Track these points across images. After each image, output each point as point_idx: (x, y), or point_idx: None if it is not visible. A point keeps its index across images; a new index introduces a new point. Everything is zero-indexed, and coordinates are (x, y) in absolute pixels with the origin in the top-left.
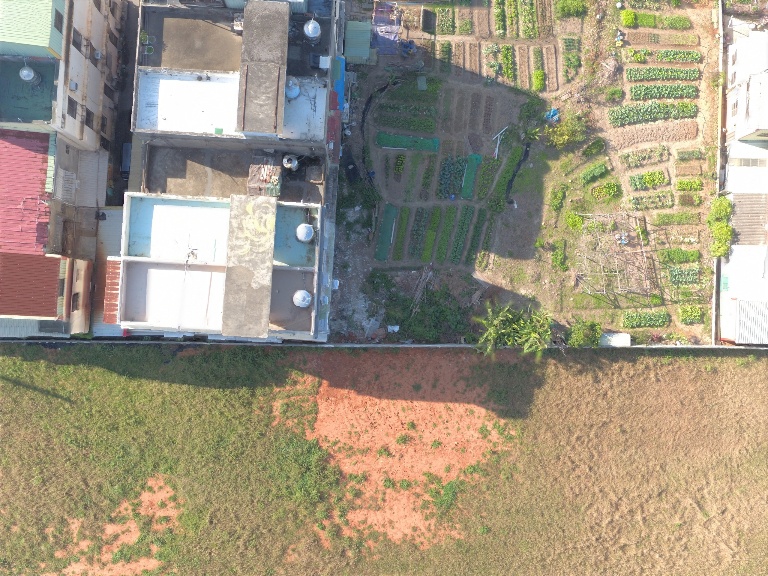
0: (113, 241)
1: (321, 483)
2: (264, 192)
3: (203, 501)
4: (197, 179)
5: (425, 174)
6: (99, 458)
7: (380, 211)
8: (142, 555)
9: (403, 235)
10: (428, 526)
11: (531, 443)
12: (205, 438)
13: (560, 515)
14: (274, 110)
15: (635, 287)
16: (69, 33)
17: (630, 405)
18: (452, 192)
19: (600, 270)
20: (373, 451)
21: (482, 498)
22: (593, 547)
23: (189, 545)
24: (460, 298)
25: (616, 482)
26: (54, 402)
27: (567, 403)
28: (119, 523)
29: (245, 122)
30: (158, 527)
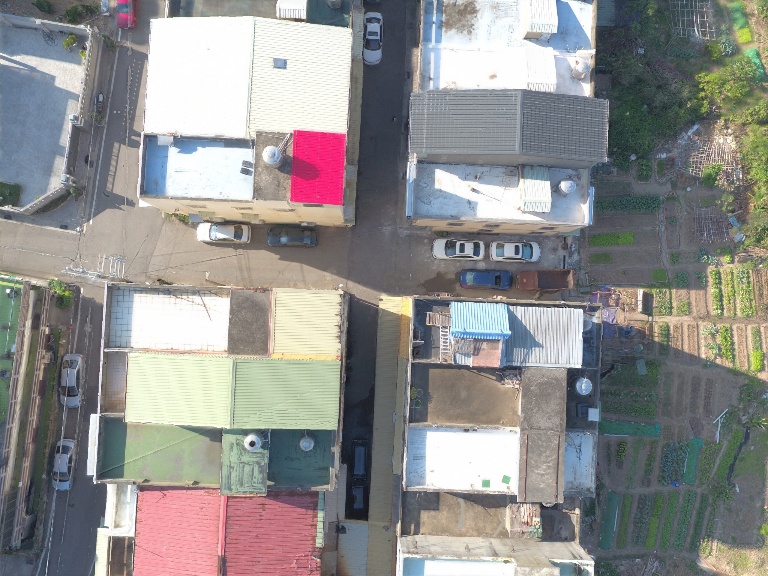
0: (354, 556)
1: None
2: (526, 535)
3: None
4: (450, 510)
5: (647, 461)
6: None
7: (603, 498)
8: None
9: (626, 523)
10: None
11: None
12: None
13: None
14: (555, 479)
15: None
16: (340, 392)
17: None
18: (674, 478)
19: None
20: None
21: None
22: None
23: None
24: None
25: None
26: None
27: None
28: None
29: (526, 492)
30: None
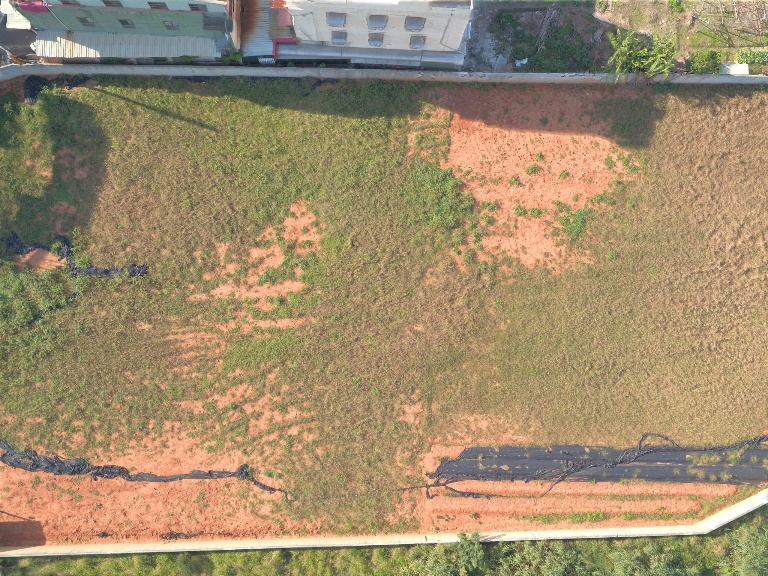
0: None
1: (456, 208)
2: None
3: (345, 225)
4: None
5: None
6: (244, 184)
7: None
8: (287, 277)
9: None
10: (559, 252)
11: (655, 173)
12: (345, 165)
13: (685, 241)
14: None
15: (748, 27)
16: None
17: (747, 138)
18: None
19: (714, 11)
20: (504, 181)
21: (610, 225)
22: (718, 272)
23: (332, 267)
24: (583, 34)
25: (737, 210)
26: (200, 131)
27: (688, 135)
28: (264, 247)
29: None
30: (301, 251)
